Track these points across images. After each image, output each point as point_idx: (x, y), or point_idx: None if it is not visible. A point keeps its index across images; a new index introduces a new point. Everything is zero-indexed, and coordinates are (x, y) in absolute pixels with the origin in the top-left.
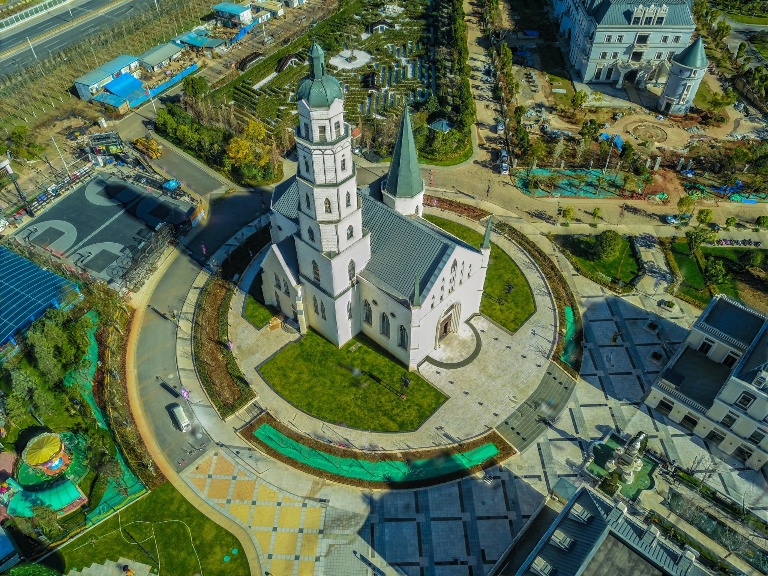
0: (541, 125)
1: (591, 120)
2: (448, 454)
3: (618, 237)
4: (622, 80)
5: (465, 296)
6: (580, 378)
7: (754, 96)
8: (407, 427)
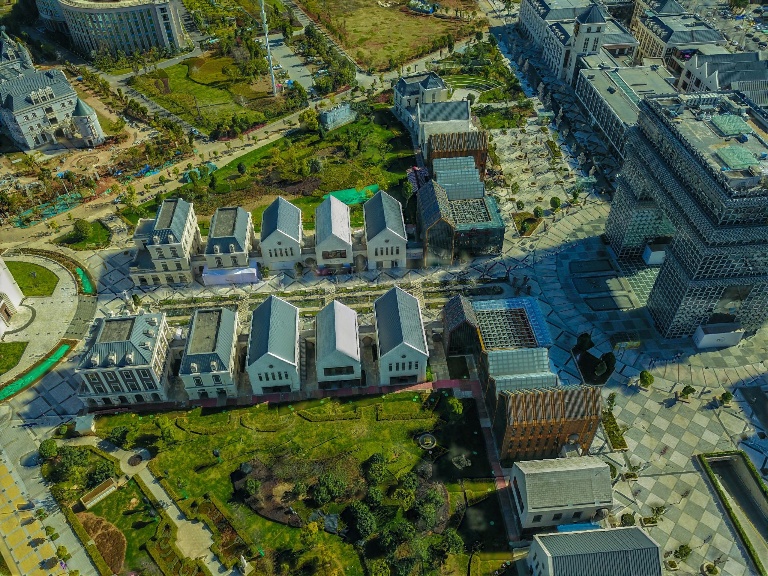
0: (15, 186)
1: (41, 169)
2: (42, 362)
3: (85, 221)
4: (55, 138)
5: (6, 290)
6: (99, 294)
7: (139, 116)
8: (11, 366)
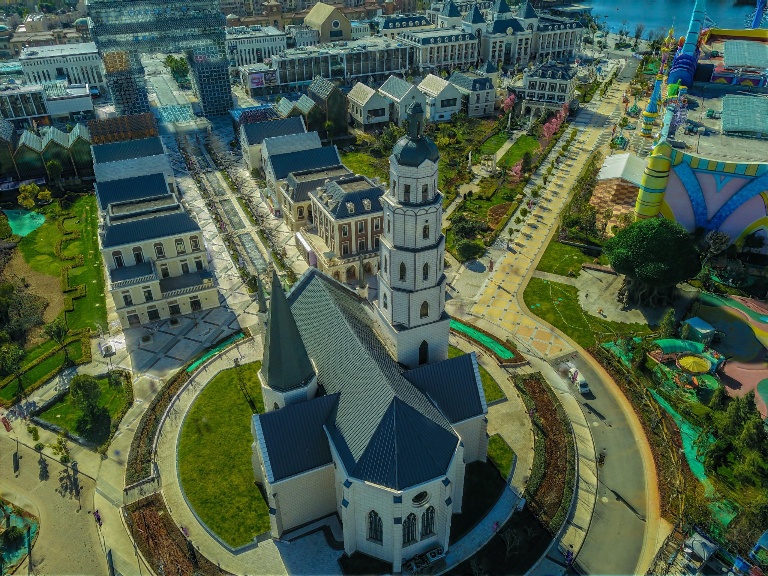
0: None
1: None
2: None
3: None
4: None
5: None
6: None
7: None
8: None
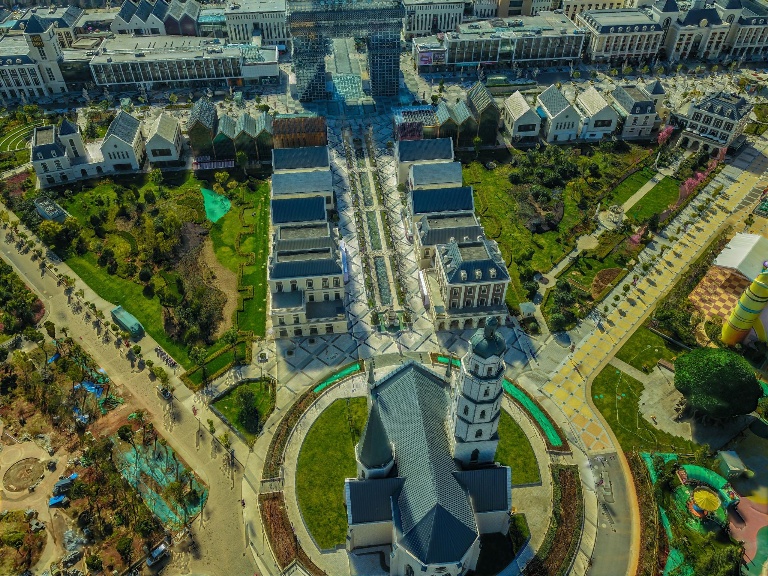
0: (67, 567)
1: (79, 487)
2: None
3: None
4: None
5: None
6: None
7: None
8: None
